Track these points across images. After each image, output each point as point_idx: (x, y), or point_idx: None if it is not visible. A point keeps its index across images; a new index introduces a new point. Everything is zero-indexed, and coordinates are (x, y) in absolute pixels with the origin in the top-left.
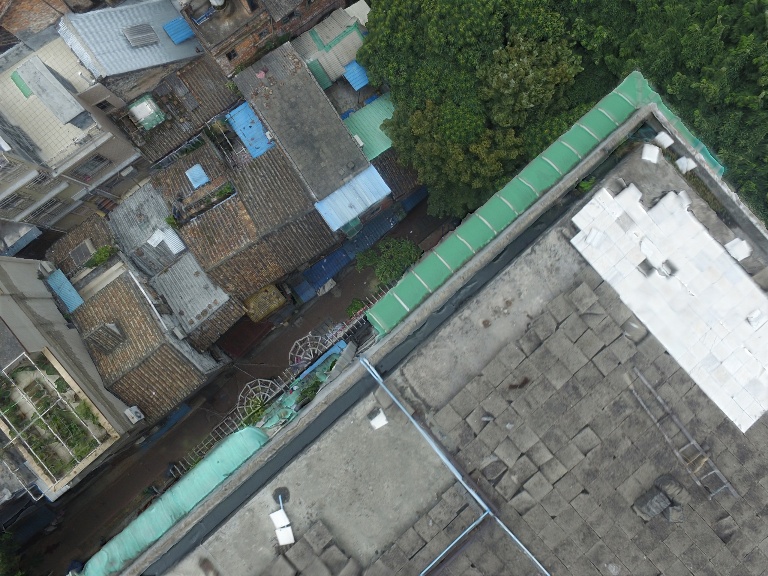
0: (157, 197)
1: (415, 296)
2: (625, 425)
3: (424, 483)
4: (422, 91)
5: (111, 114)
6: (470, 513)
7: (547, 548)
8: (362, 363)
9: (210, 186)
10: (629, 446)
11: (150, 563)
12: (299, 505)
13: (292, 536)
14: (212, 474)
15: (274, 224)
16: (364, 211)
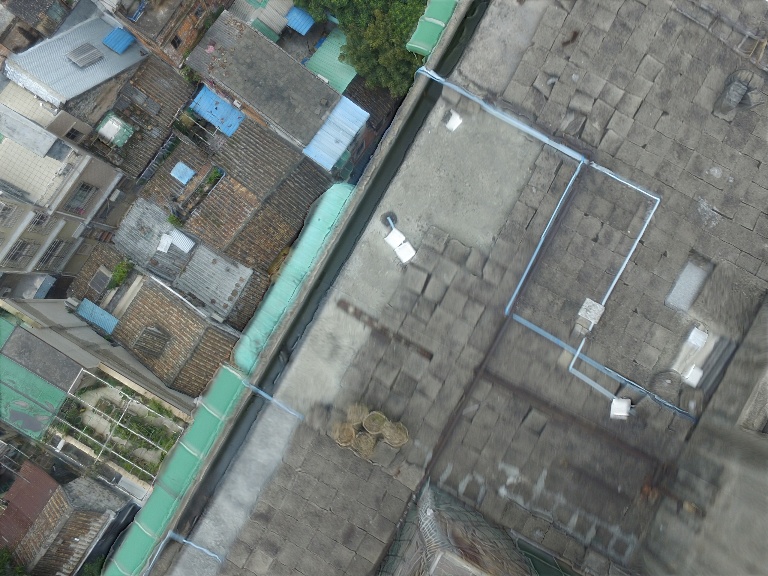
0: (152, 207)
1: (445, 10)
2: (680, 43)
3: (514, 163)
4: (367, 5)
5: (82, 143)
6: (567, 169)
7: (648, 176)
8: (420, 72)
9: (198, 177)
10: (690, 59)
11: (291, 314)
12: (408, 222)
13: (411, 249)
14: (317, 232)
15: (271, 185)
16: (351, 144)
